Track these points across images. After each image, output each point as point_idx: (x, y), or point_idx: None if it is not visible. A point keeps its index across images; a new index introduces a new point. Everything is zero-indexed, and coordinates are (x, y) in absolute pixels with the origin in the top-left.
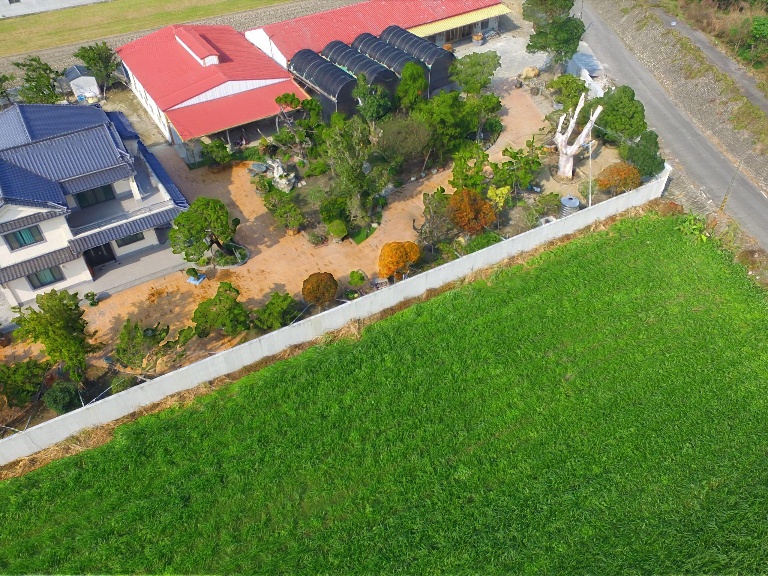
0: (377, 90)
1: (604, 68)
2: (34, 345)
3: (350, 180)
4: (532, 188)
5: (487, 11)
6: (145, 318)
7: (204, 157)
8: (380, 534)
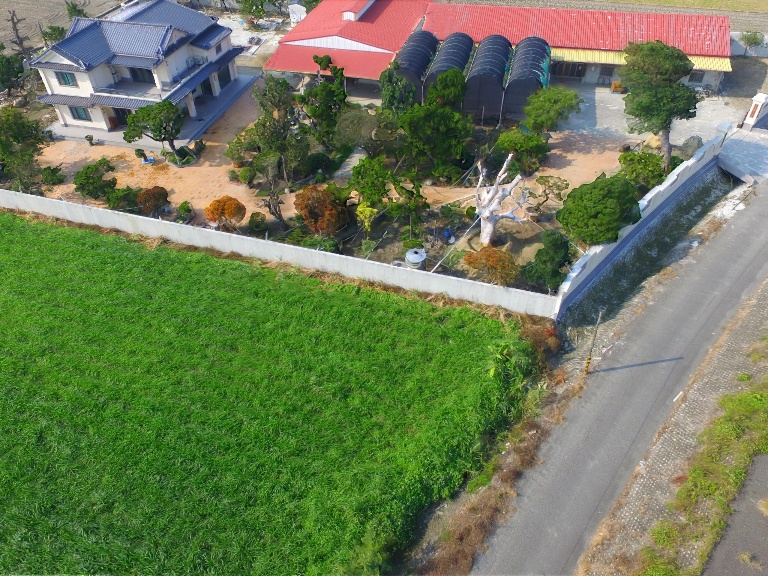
0: (401, 82)
1: None
2: None
3: (260, 136)
4: (449, 237)
5: (696, 60)
6: None
7: None
8: None
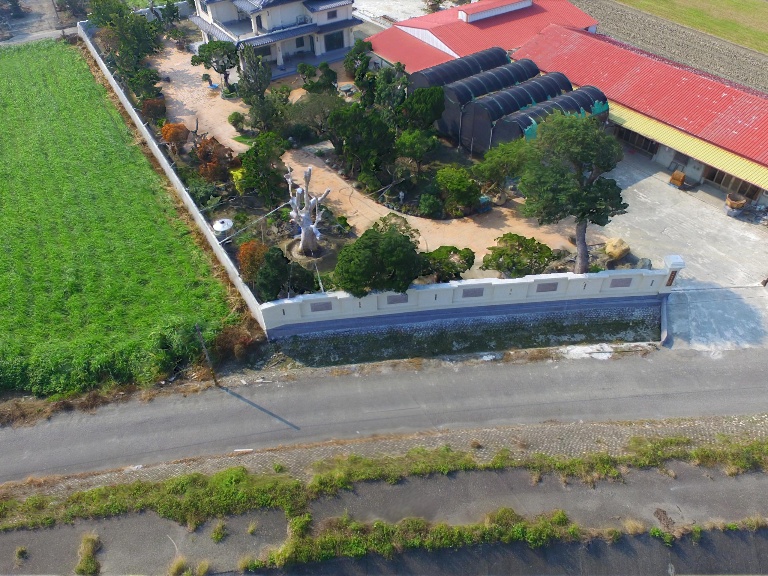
0: None
1: (698, 349)
2: (175, 55)
3: None
4: None
5: None
6: (183, 77)
7: None
8: None
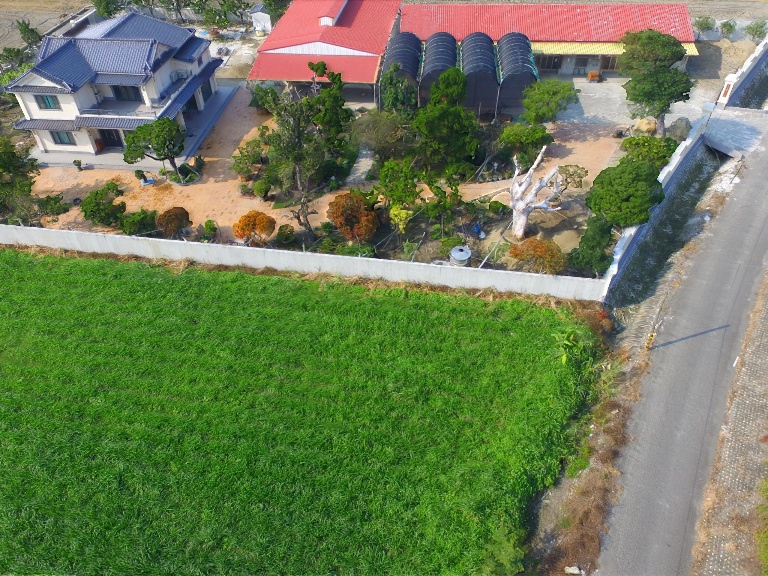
0: (403, 83)
1: (754, 151)
2: None
3: (276, 147)
4: (479, 232)
5: None
6: None
7: (254, 98)
8: (1, 397)
